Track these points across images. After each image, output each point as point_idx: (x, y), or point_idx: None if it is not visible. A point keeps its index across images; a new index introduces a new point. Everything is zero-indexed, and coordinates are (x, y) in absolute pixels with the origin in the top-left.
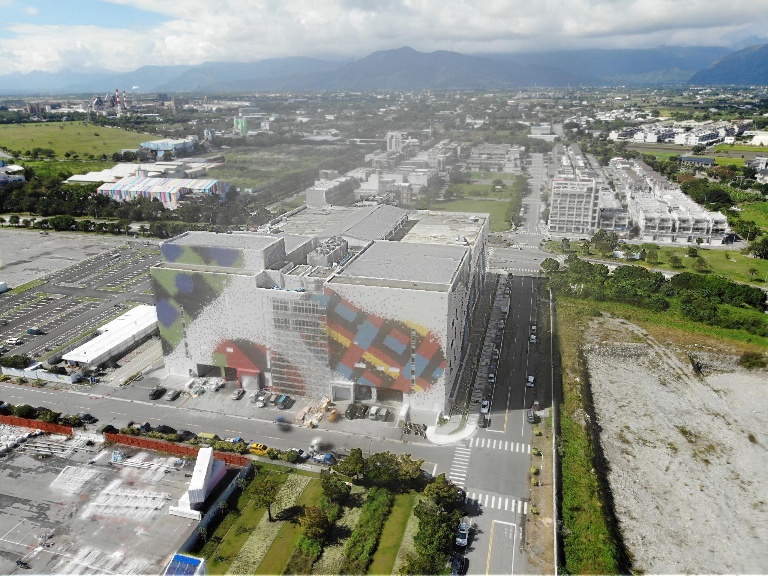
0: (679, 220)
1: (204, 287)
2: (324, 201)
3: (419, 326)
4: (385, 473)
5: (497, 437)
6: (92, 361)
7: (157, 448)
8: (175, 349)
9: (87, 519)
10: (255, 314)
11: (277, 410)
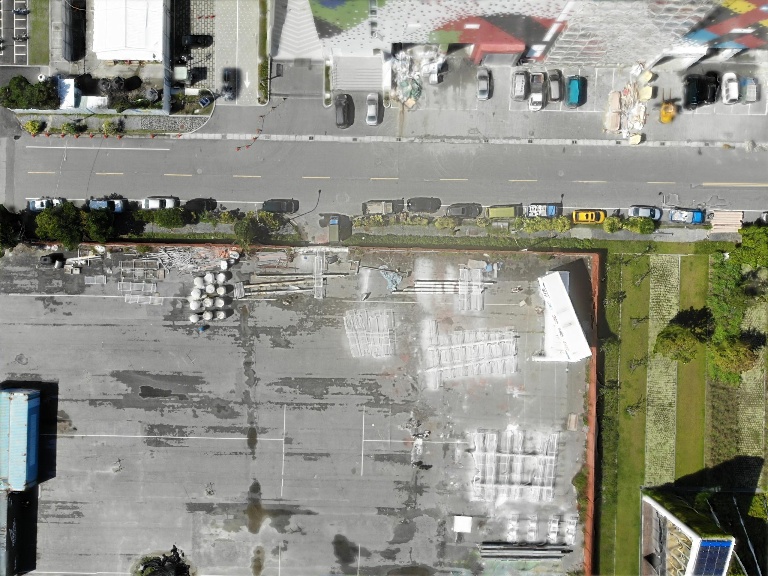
0: None
1: None
2: None
3: None
4: None
5: None
6: (162, 53)
7: None
8: (346, 31)
9: (439, 390)
10: None
11: (566, 111)
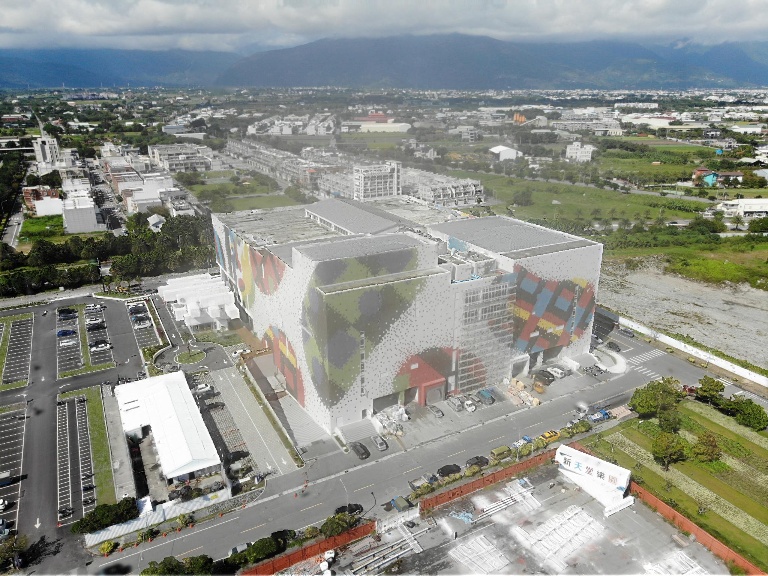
0: (453, 188)
1: (393, 300)
2: (94, 222)
3: (582, 280)
4: (667, 397)
5: (637, 353)
6: (219, 460)
7: (483, 485)
8: (347, 392)
9: (569, 569)
10: (446, 315)
11: (489, 406)
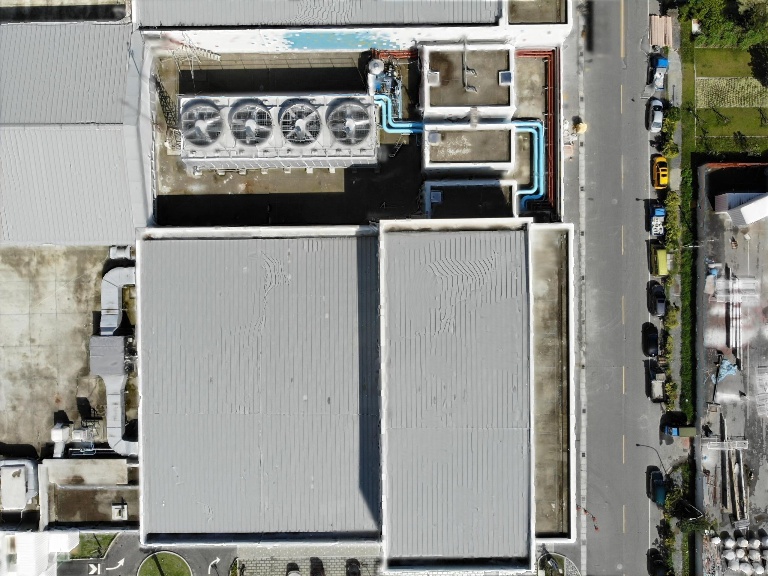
0: None
1: None
2: None
3: None
4: None
5: None
6: None
7: None
8: None
9: None
10: None
11: None
